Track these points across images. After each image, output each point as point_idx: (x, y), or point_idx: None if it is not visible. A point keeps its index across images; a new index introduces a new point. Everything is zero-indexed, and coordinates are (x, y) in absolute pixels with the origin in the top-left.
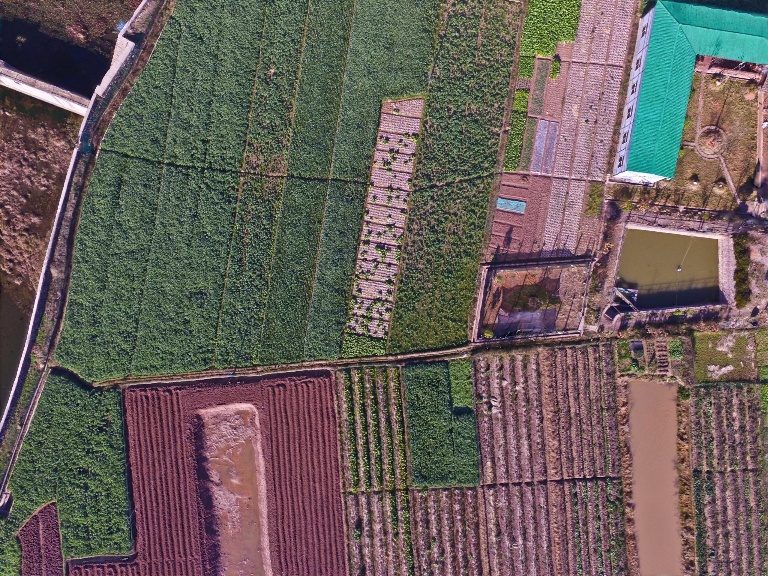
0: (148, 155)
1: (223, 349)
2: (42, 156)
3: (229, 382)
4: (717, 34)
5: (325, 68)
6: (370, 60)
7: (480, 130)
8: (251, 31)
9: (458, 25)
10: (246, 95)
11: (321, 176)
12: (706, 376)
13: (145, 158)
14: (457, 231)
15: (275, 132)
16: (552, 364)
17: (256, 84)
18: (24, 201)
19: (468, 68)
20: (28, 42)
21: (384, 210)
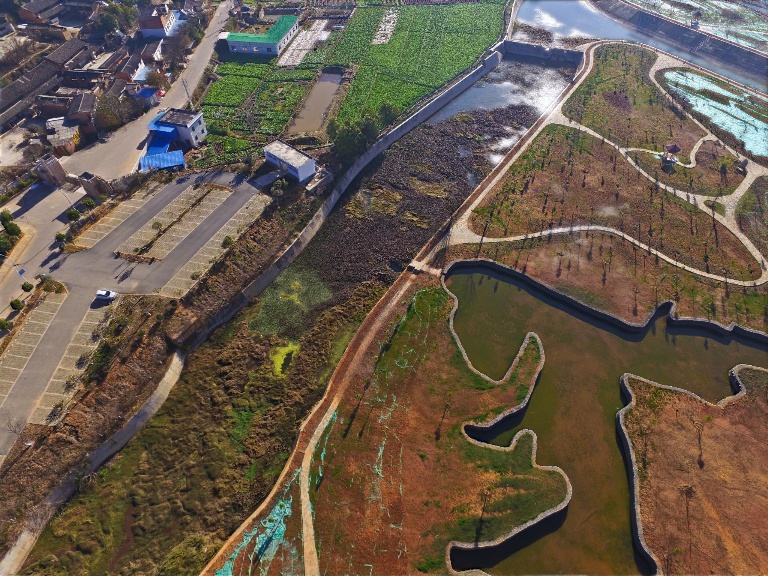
0: None
1: (445, 7)
2: None
3: (442, 4)
4: (255, 36)
5: None
6: None
7: None
8: None
9: None
10: None
11: None
12: (275, 2)
13: None
14: None
15: None
16: (329, 3)
17: None
18: None
19: None
20: None
21: None
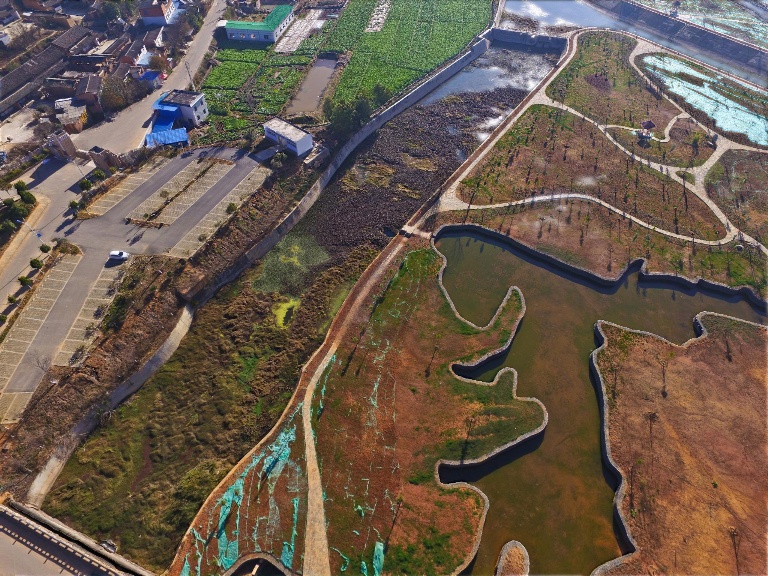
0: None
1: None
2: None
3: None
4: None
5: None
6: None
7: None
8: None
9: None
10: None
11: None
12: None
13: None
14: None
15: None
16: None
17: None
18: None
19: None
20: None
21: None
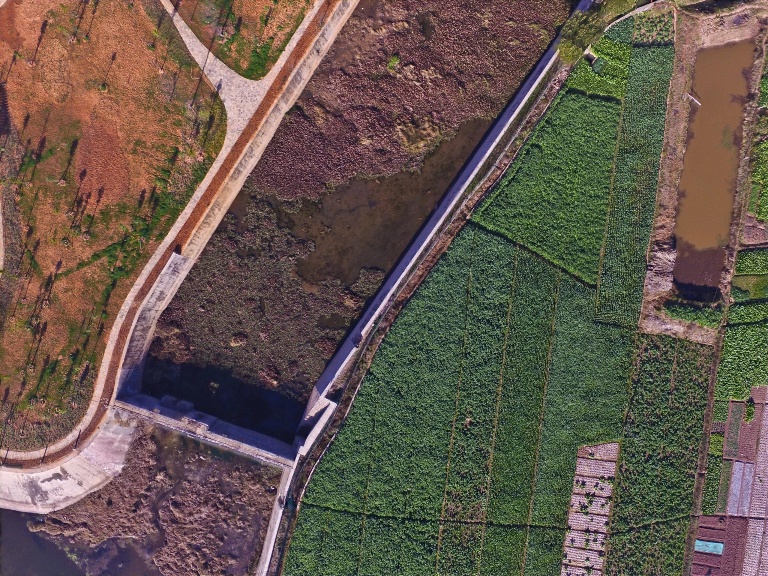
0: (349, 508)
1: None
2: (238, 499)
3: None
4: None
5: (522, 418)
6: (567, 410)
7: (676, 473)
8: (449, 384)
9: (651, 370)
10: (444, 446)
11: (519, 522)
12: None
13: (346, 510)
14: (655, 572)
15: (473, 480)
16: None
17: (454, 434)
18: (221, 544)
19: (662, 412)
20: (221, 387)
21: (582, 553)
